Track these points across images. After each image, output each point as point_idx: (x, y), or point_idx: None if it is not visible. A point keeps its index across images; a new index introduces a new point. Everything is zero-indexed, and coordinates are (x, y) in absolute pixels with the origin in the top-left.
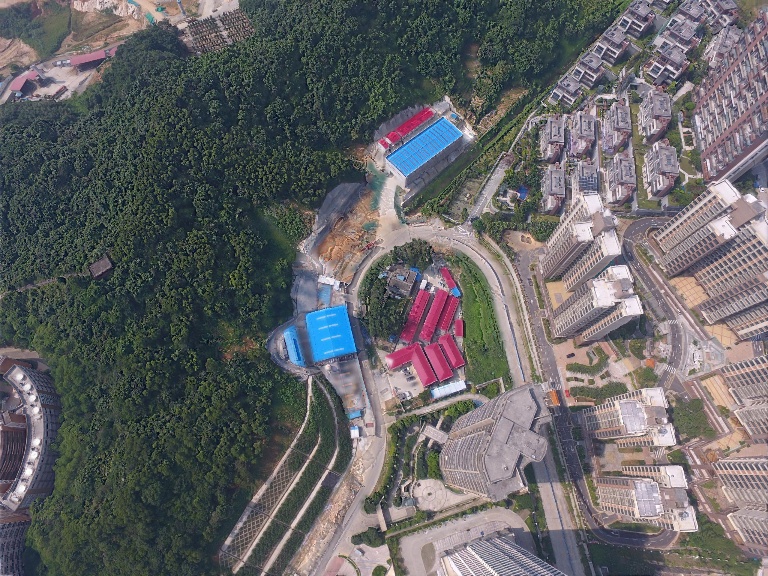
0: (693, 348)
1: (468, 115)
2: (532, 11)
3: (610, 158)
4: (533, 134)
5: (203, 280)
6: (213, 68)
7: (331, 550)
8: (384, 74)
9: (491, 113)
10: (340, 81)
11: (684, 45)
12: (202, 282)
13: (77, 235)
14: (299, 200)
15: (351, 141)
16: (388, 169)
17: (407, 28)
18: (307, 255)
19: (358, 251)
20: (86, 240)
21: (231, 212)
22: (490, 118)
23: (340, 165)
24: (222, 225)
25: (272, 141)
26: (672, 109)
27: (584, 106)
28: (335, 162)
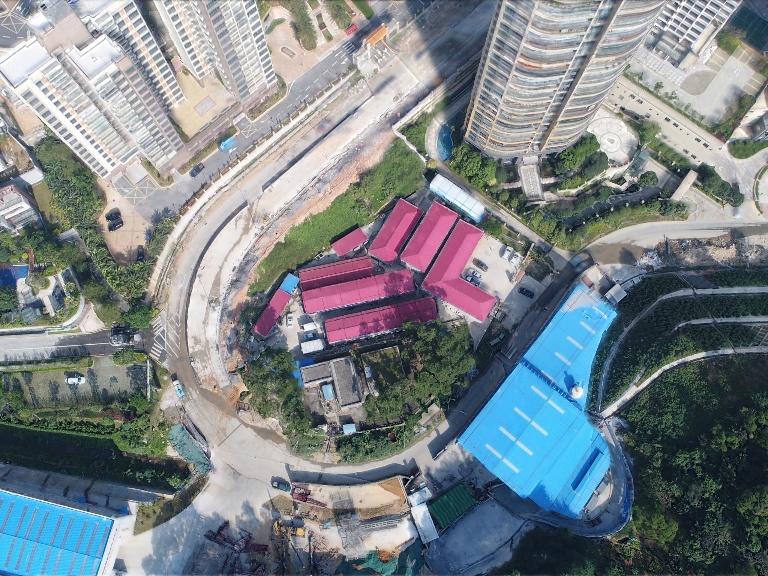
0: None
1: None
2: None
3: None
4: None
5: None
6: None
7: (764, 228)
8: None
9: None
10: None
11: None
12: None
13: None
14: None
15: None
16: None
17: None
18: None
19: (326, 510)
20: None
21: None
22: None
23: None
24: None
25: None
26: None
27: None
28: None
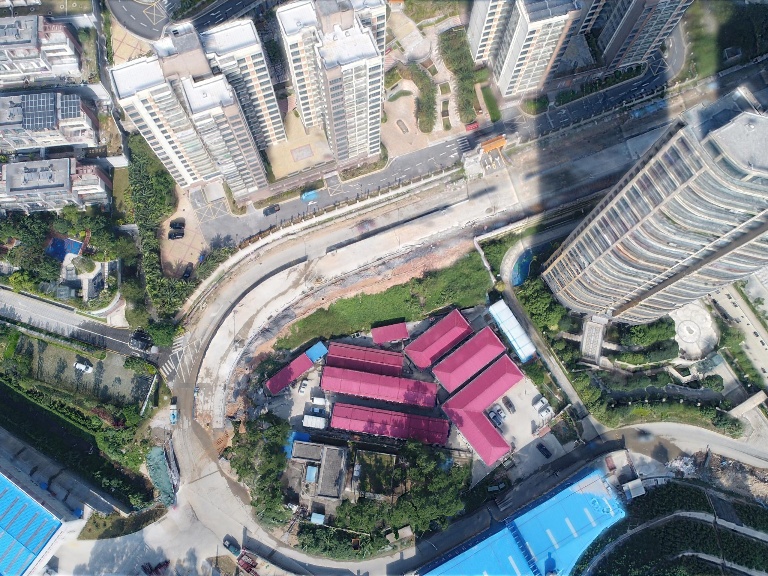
0: None
1: None
2: None
3: None
4: None
5: None
6: None
7: None
8: None
9: None
10: None
11: None
12: None
13: None
14: None
15: None
16: (38, 574)
17: None
18: None
19: None
20: None
21: None
22: None
23: None
24: None
25: None
26: None
27: None
28: None
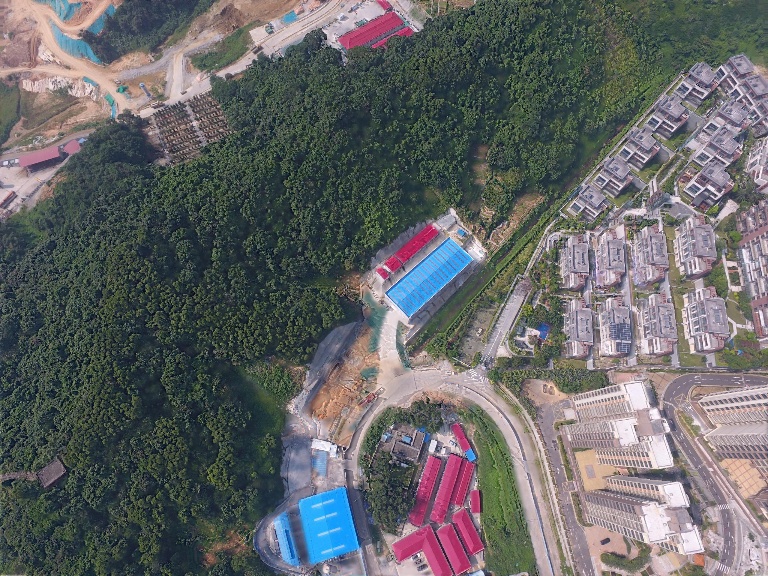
0: (749, 543)
1: (477, 229)
2: (548, 111)
3: (643, 293)
4: (553, 258)
5: (176, 481)
6: (180, 199)
7: None
8: (381, 195)
9: (502, 224)
10: (330, 205)
11: (726, 158)
12: (175, 483)
13: (26, 413)
14: (287, 358)
15: (344, 270)
16: (388, 303)
17: (405, 133)
18: (298, 415)
19: (356, 404)
20: (35, 429)
21: (207, 384)
22: (502, 231)
23: (333, 313)
24: (197, 402)
25: (253, 280)
26: (716, 243)
27: (609, 220)
28: (327, 310)
